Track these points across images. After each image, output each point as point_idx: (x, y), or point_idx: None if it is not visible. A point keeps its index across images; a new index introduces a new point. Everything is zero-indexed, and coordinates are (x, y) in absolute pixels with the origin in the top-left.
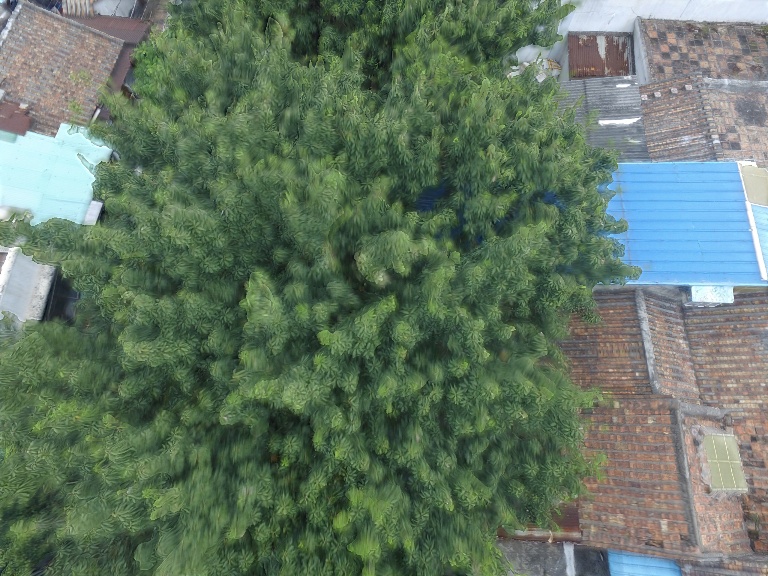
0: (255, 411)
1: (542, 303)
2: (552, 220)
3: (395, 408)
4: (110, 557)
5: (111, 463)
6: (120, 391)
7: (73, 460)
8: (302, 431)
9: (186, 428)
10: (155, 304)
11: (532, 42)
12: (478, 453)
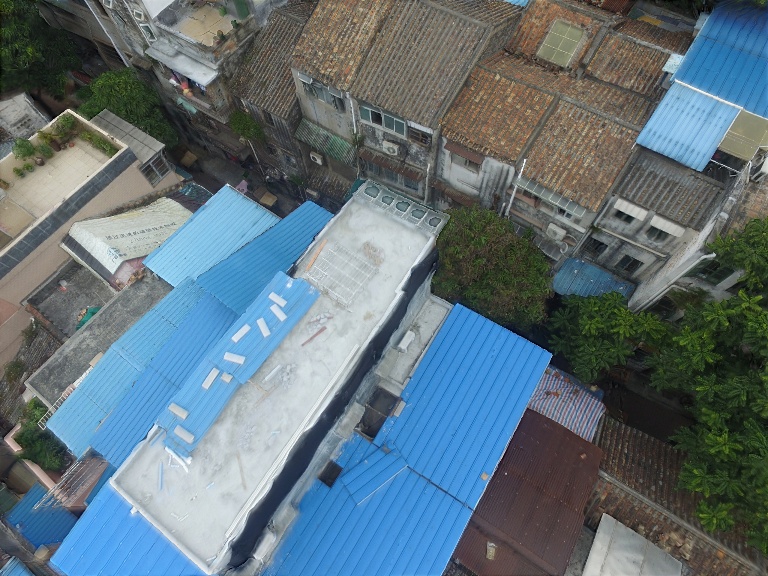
0: None
1: None
2: None
3: None
4: None
5: None
6: None
7: None
8: None
9: None
10: None
11: None
12: None
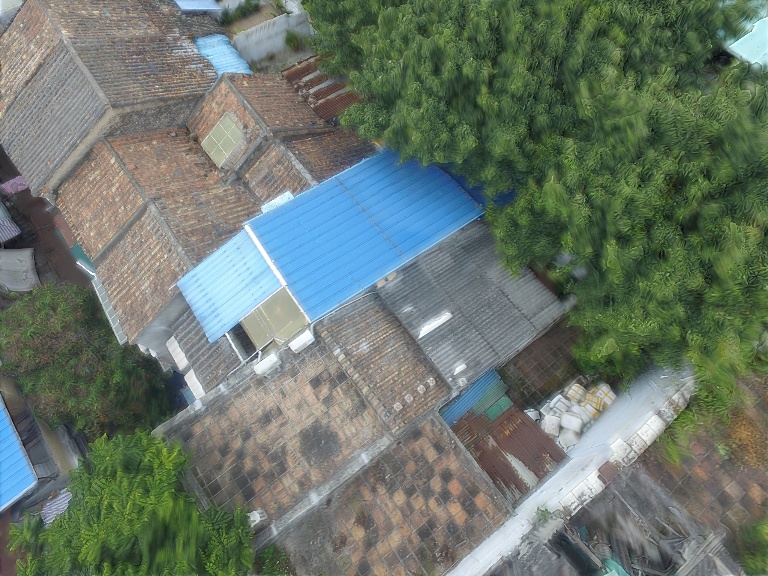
0: None
1: None
2: None
3: None
4: None
5: None
6: None
7: None
8: None
9: None
10: None
11: None
12: None
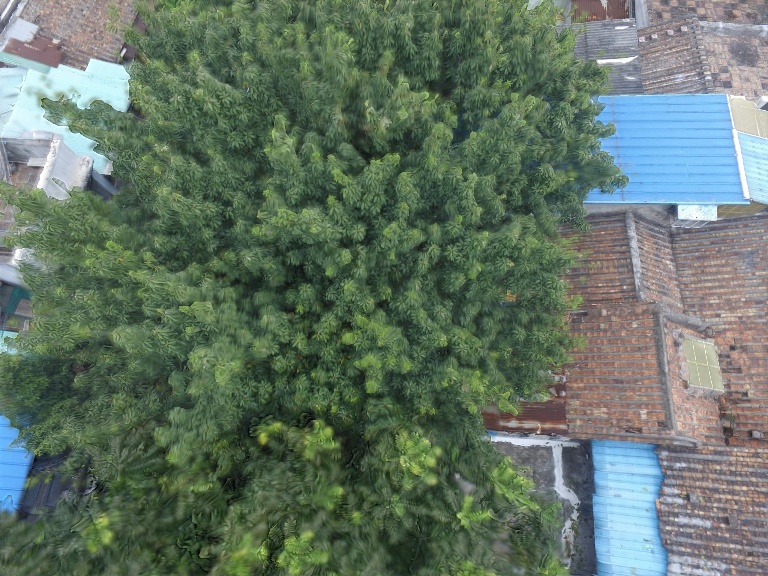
0: (275, 260)
1: (533, 191)
2: (543, 108)
3: (398, 270)
4: (145, 394)
5: (151, 292)
6: (156, 243)
7: (114, 308)
8: (315, 287)
9: (214, 274)
10: (189, 165)
11: None
12: (471, 315)
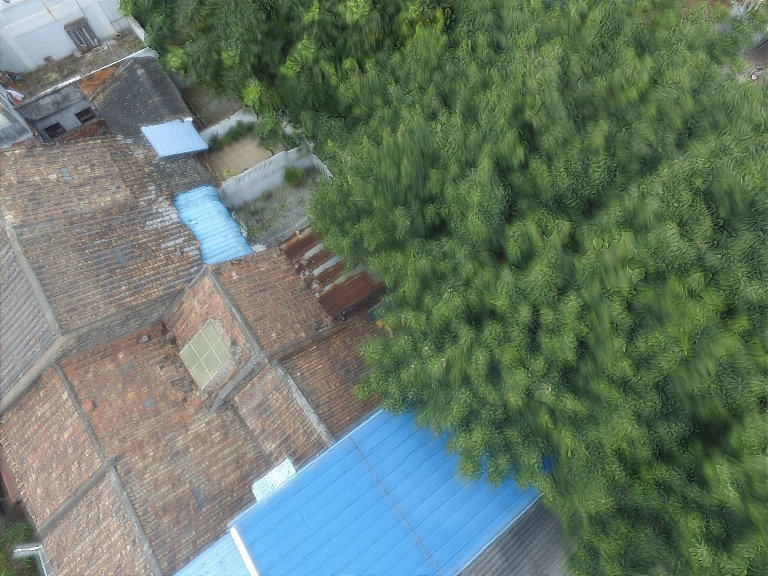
0: None
1: None
2: (472, 264)
3: None
4: None
5: None
6: None
7: None
8: None
9: None
10: None
11: (679, 574)
12: None
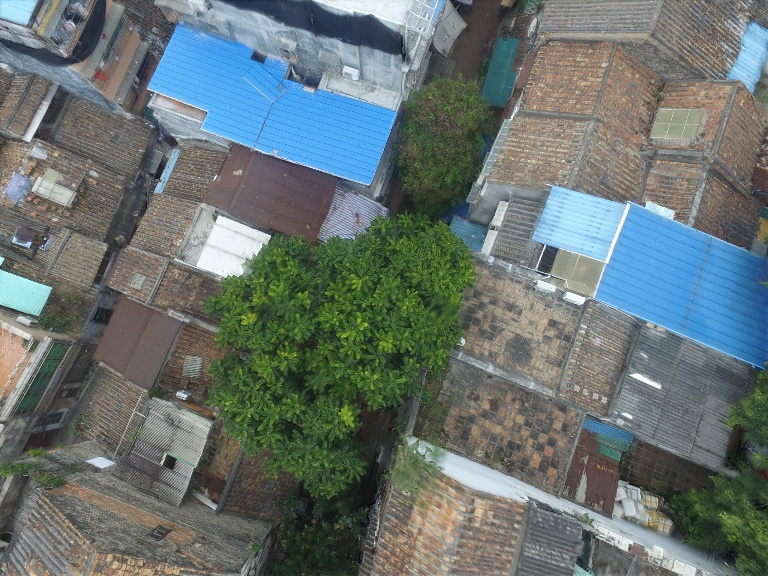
0: None
1: None
2: None
3: None
4: None
5: None
6: None
7: None
8: None
9: None
10: None
11: None
12: None
